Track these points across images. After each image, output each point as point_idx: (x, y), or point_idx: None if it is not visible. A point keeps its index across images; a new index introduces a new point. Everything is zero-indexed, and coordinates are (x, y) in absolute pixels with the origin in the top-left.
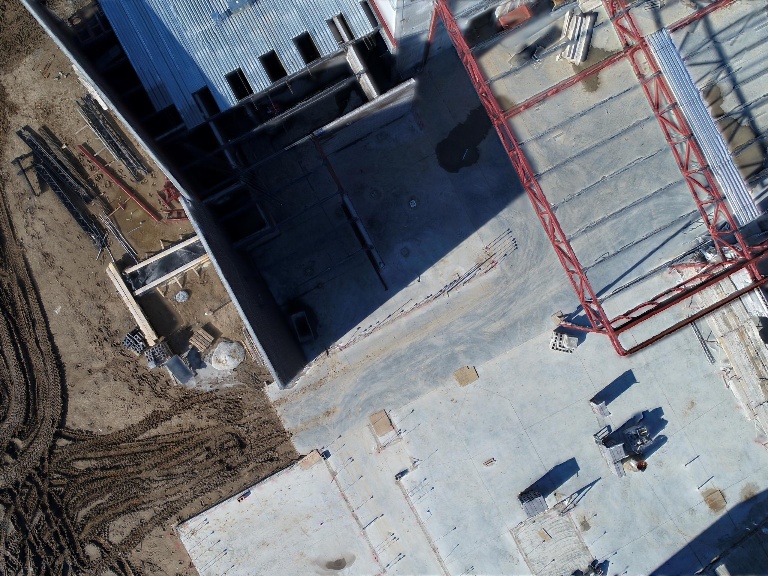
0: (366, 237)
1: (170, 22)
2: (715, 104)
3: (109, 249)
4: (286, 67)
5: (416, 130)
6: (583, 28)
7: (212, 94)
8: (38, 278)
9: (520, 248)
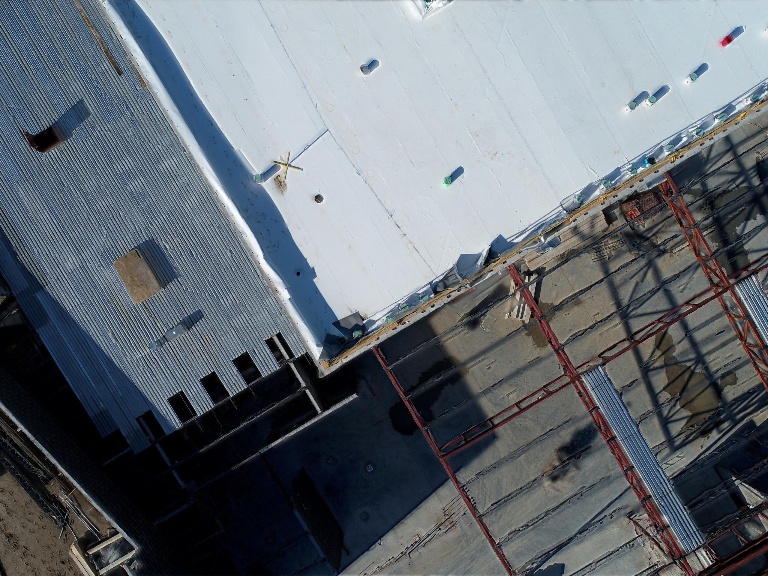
0: (318, 550)
1: (109, 349)
2: (668, 352)
3: (71, 527)
4: (228, 388)
5: (369, 395)
6: (531, 286)
7: (156, 418)
8: (3, 558)
9: (479, 506)
